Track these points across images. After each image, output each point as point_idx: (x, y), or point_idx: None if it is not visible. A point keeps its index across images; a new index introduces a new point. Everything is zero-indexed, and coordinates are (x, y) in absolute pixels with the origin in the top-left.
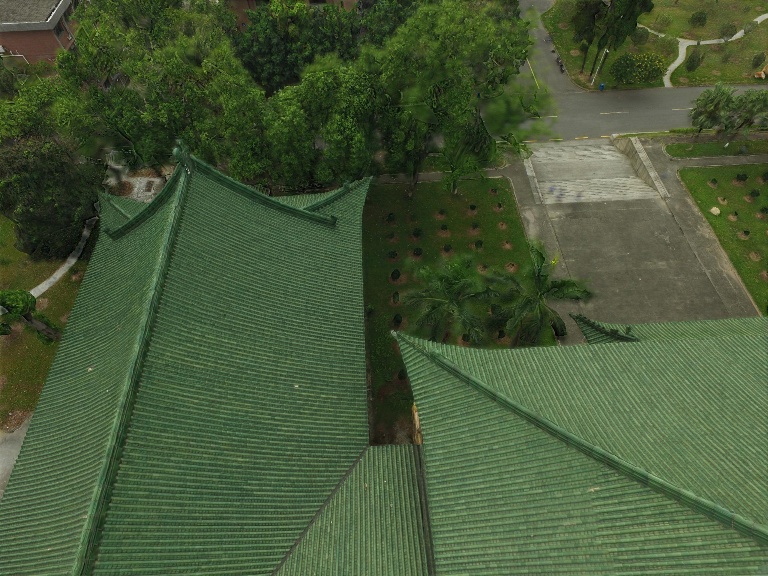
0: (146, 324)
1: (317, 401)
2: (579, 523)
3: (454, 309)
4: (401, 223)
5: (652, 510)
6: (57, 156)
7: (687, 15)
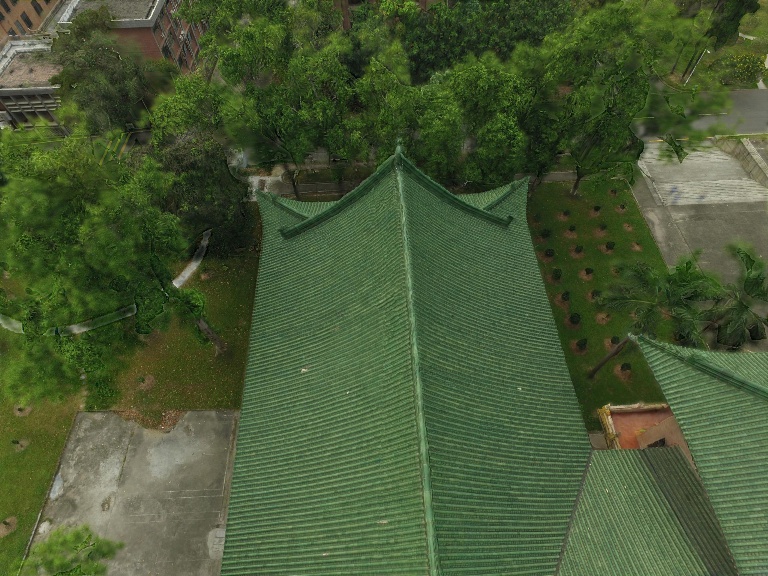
0: (415, 325)
1: (539, 404)
2: None
3: (683, 312)
4: None
5: None
6: (218, 154)
7: (767, 16)
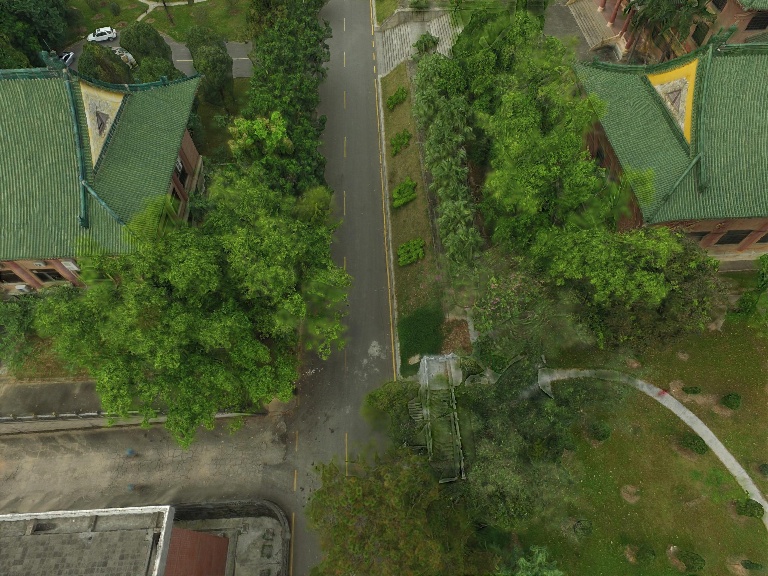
0: None
1: None
2: None
3: None
4: None
5: None
6: None
7: None
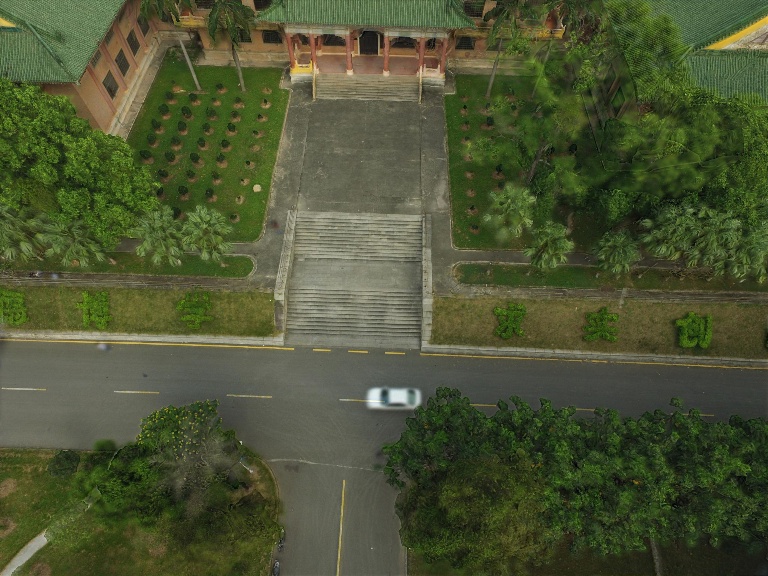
0: None
1: None
2: None
3: None
4: None
5: None
6: None
7: None
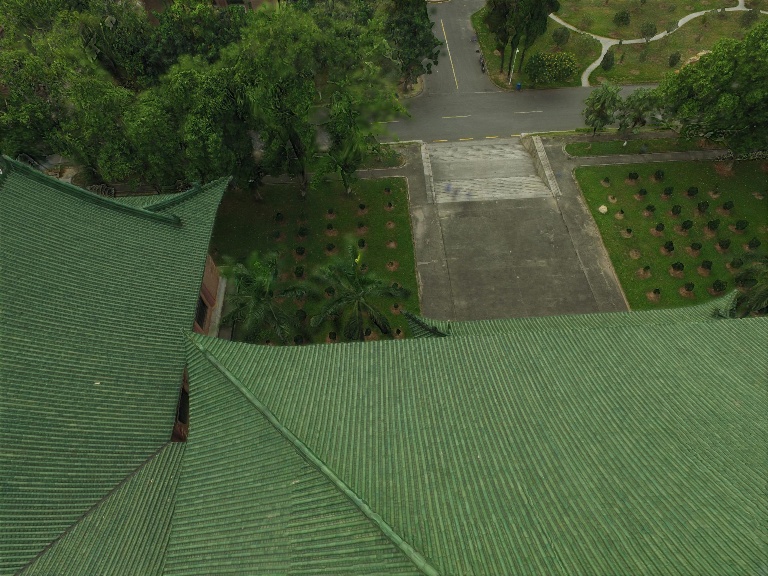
0: None
1: (119, 398)
2: (278, 515)
3: (251, 306)
4: (291, 222)
5: (328, 502)
6: None
7: None
